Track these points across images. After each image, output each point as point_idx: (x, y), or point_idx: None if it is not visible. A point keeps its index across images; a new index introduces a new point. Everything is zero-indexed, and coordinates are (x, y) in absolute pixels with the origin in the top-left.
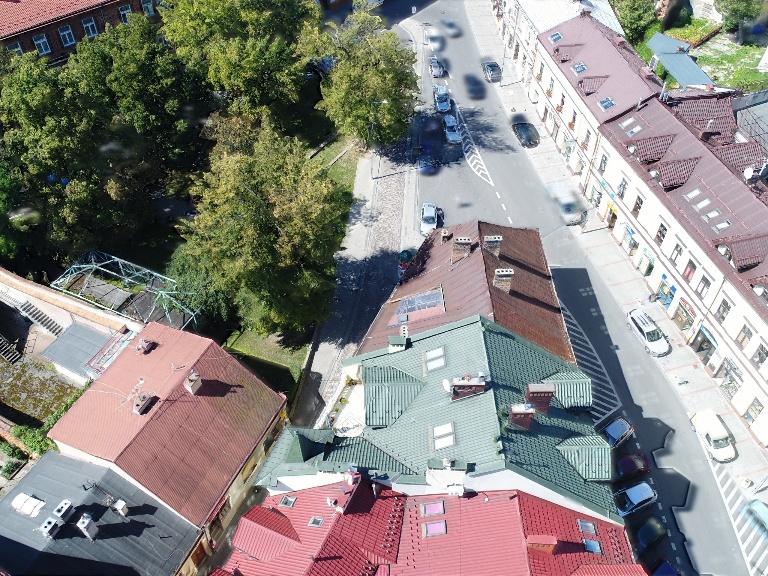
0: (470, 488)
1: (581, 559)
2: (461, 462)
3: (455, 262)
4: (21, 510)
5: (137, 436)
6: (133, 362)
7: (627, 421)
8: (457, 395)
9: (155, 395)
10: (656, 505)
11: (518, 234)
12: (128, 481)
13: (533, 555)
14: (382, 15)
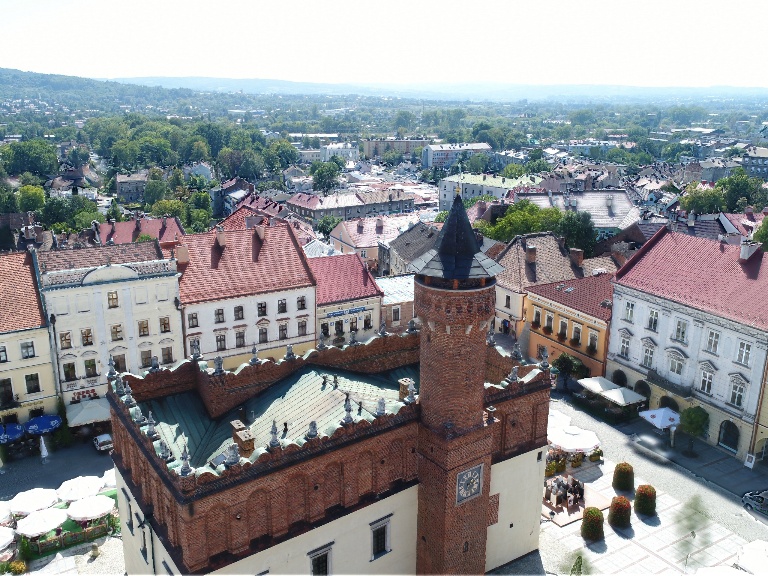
0: None
1: None
2: None
3: None
4: None
5: None
6: None
7: None
8: None
9: None
10: None
11: None
12: None
13: None
14: None
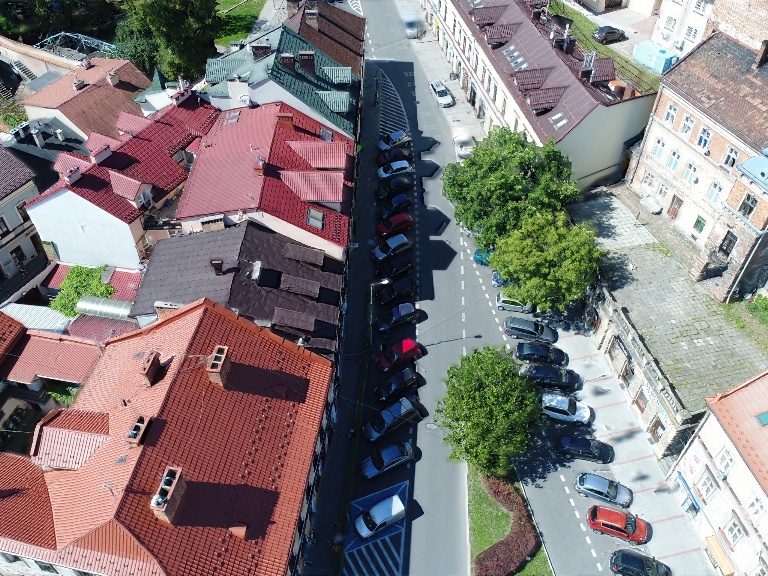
0: (255, 101)
1: (315, 140)
2: (245, 77)
3: (290, 18)
4: (1, 139)
5: (73, 98)
6: None
7: None
8: (256, 56)
9: (88, 83)
10: (412, 175)
11: (345, 14)
12: (67, 125)
13: (281, 126)
14: None
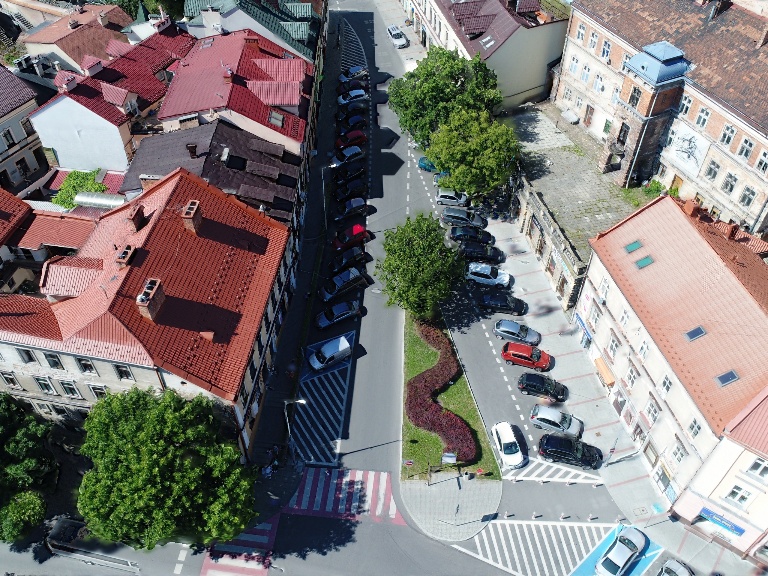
0: (226, 29)
1: None
2: (217, 7)
3: None
4: None
5: (68, 35)
6: (73, 17)
7: (363, 67)
8: None
9: None
10: (368, 102)
11: None
12: (63, 59)
13: (248, 48)
14: None
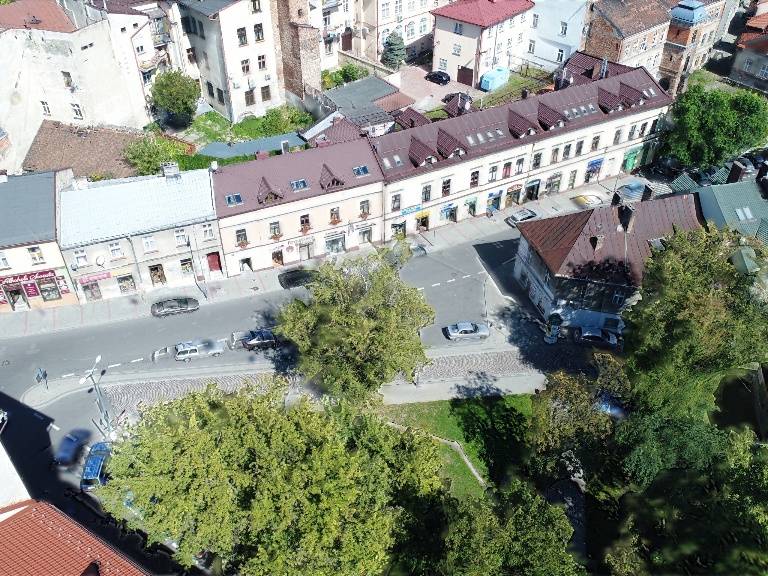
0: None
1: None
2: None
3: None
4: None
5: None
6: None
7: None
8: None
9: None
10: None
11: None
12: None
13: None
14: (2, 435)
